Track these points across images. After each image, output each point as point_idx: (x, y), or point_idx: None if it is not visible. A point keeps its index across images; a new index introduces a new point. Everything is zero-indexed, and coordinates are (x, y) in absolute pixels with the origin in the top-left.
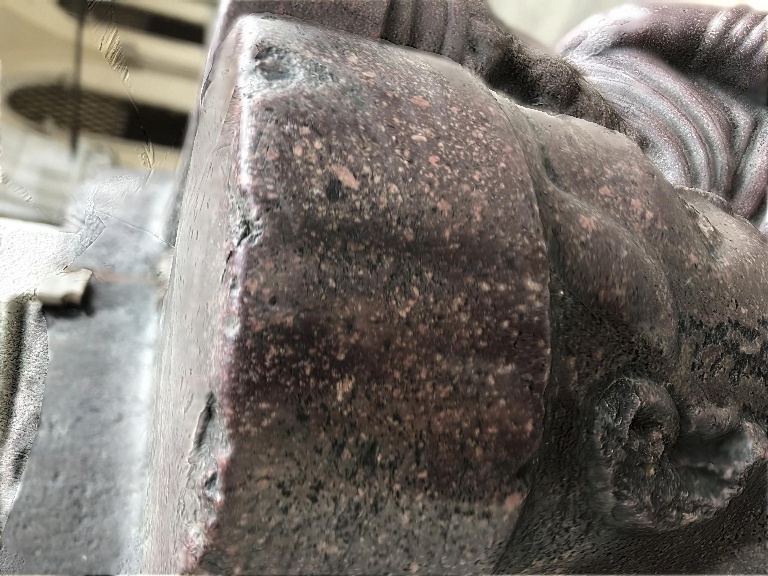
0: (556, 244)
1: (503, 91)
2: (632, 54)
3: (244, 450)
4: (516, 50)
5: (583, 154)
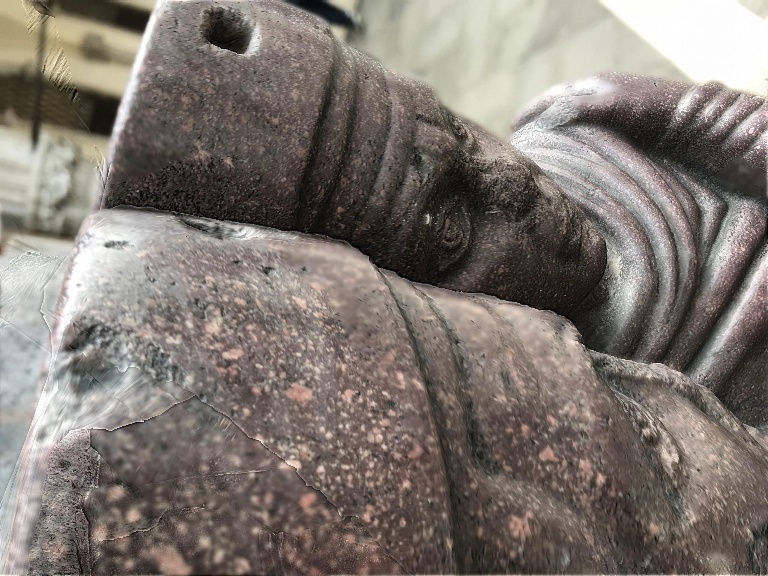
0: (476, 575)
1: (453, 199)
2: (599, 128)
3: None
4: (470, 147)
5: (522, 400)
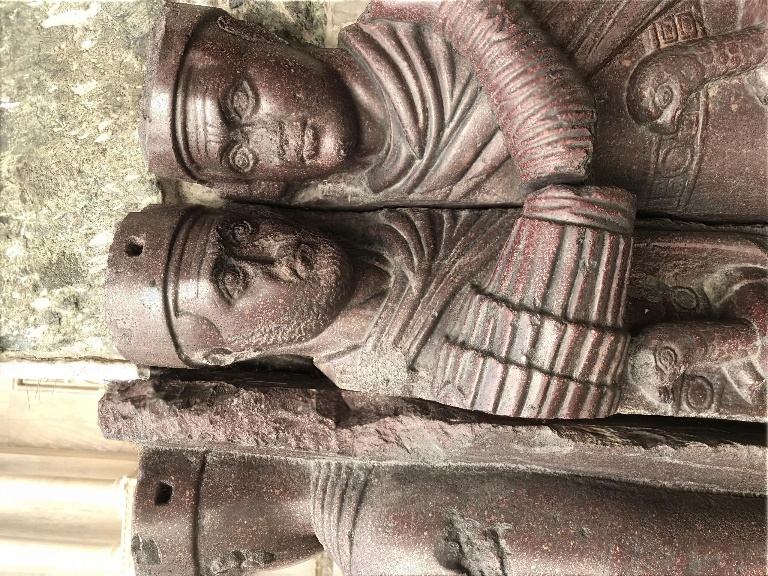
0: None
1: None
2: None
3: None
4: None
5: None
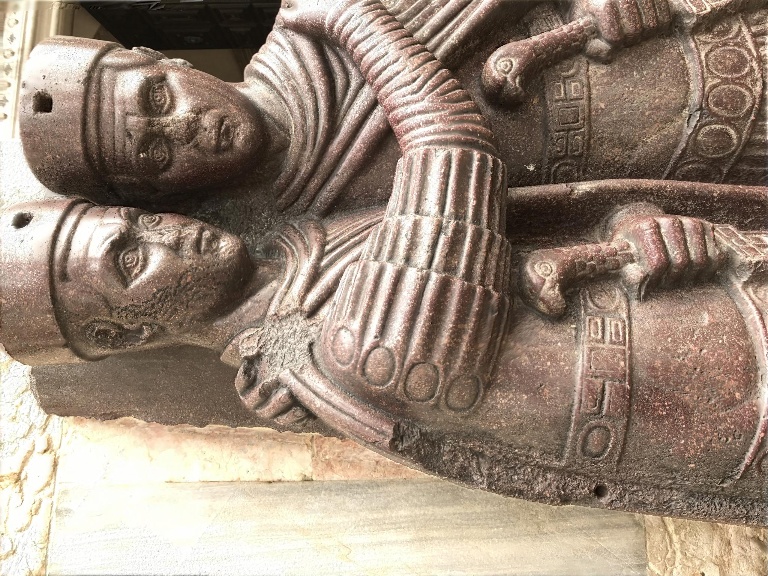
0: None
1: (156, 140)
2: (296, 31)
3: (6, 345)
4: (166, 109)
5: (81, 265)
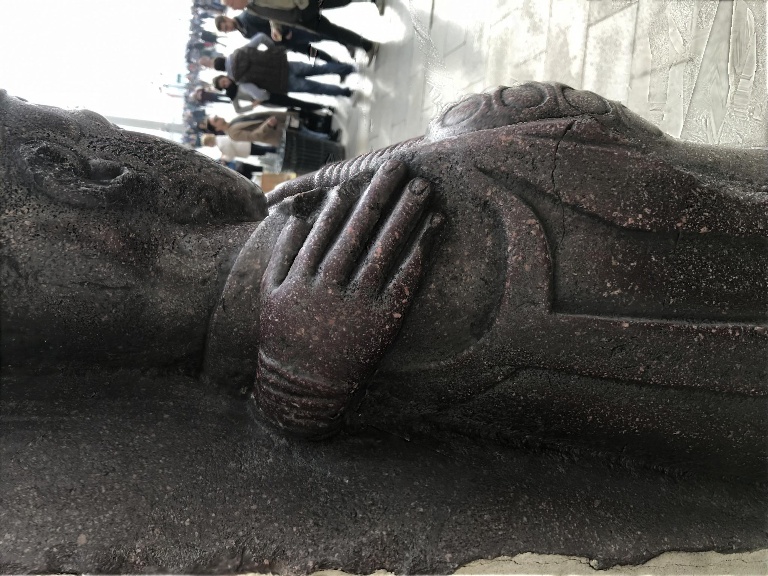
0: (7, 104)
1: None
2: None
3: None
4: None
5: None
